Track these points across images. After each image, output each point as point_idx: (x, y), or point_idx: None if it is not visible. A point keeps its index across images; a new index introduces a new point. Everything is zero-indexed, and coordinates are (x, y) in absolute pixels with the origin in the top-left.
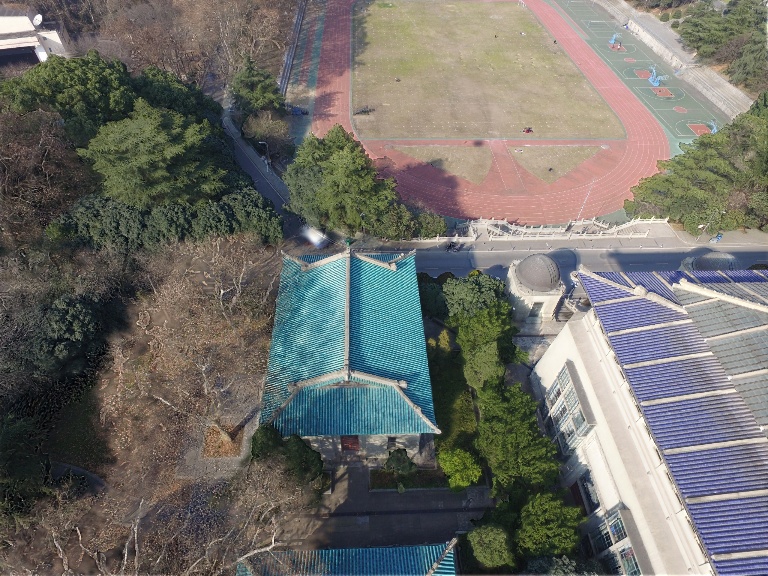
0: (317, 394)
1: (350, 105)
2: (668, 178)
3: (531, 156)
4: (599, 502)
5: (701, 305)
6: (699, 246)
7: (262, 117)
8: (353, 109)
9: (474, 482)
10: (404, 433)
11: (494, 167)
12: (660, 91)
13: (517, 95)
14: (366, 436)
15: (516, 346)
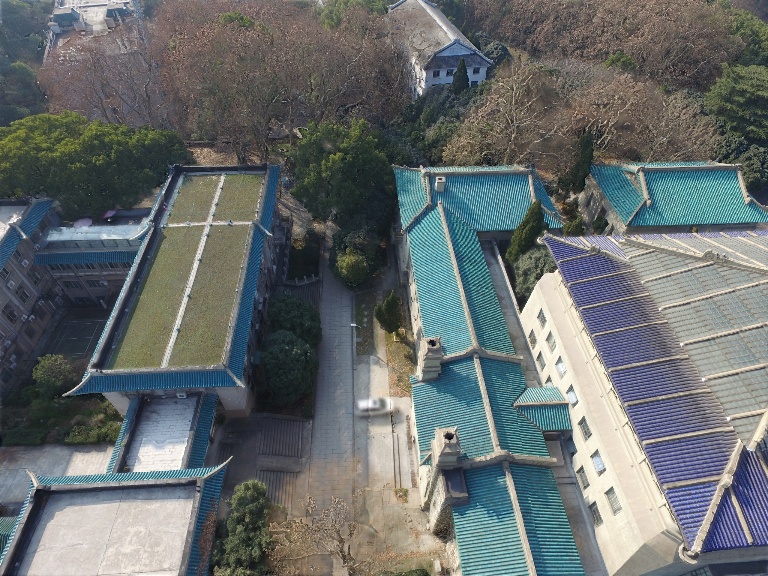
0: (621, 173)
1: None
2: None
3: None
4: None
5: None
6: None
7: None
8: None
9: None
10: None
11: None
12: None
13: None
14: None
15: None
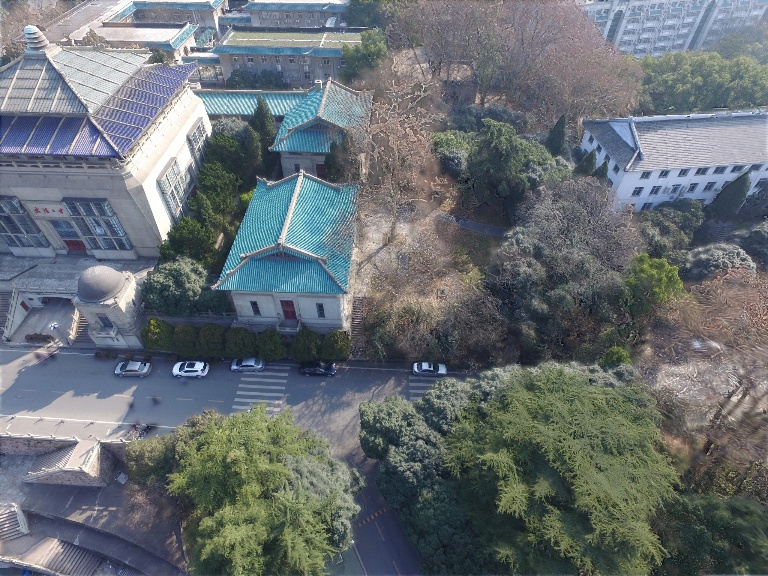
0: None
1: None
2: None
3: None
4: None
5: None
6: None
7: None
8: None
9: None
10: None
11: None
12: None
13: None
14: None
15: None
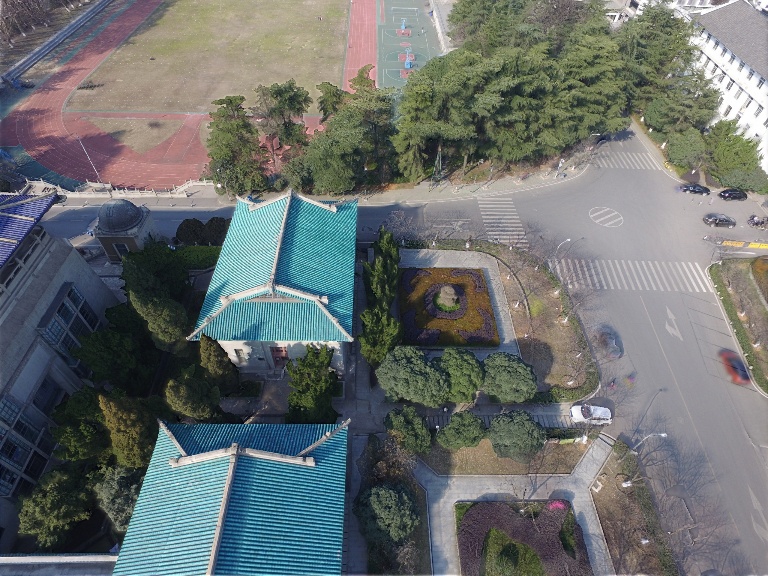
0: None
1: (83, 80)
2: None
3: None
4: None
5: None
6: (229, 206)
7: None
8: (79, 84)
9: None
10: None
11: (171, 138)
12: (407, 73)
13: (258, 74)
14: None
15: None
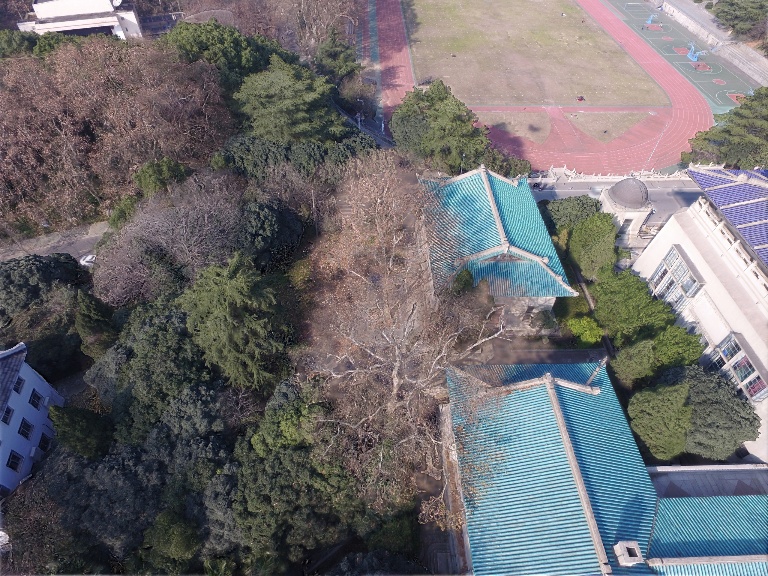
0: (479, 266)
1: (414, 77)
2: (726, 127)
3: (586, 121)
4: (708, 342)
5: None
6: None
7: (357, 79)
8: (418, 80)
9: (598, 341)
10: (548, 296)
11: (554, 130)
12: (699, 66)
13: (566, 69)
14: (512, 305)
15: (619, 247)
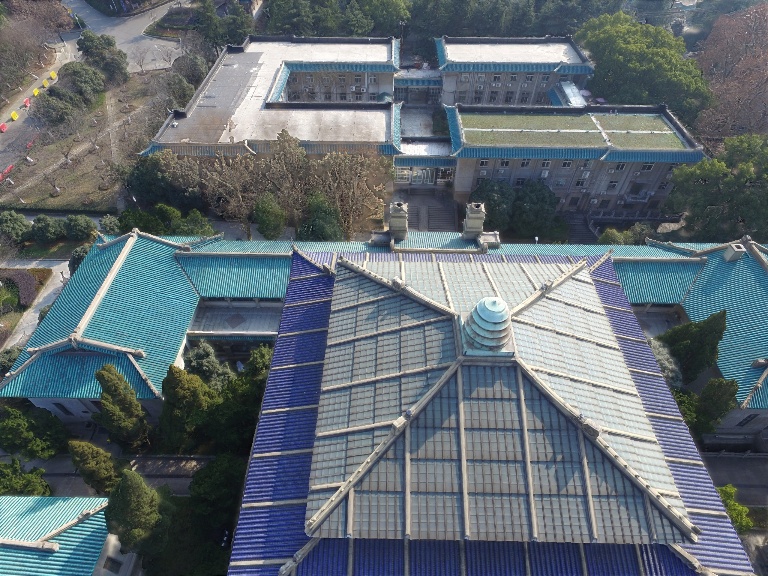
0: None
1: None
2: None
3: None
4: None
5: (664, 489)
6: None
7: None
8: None
9: None
10: None
11: None
12: None
13: None
14: None
15: None
